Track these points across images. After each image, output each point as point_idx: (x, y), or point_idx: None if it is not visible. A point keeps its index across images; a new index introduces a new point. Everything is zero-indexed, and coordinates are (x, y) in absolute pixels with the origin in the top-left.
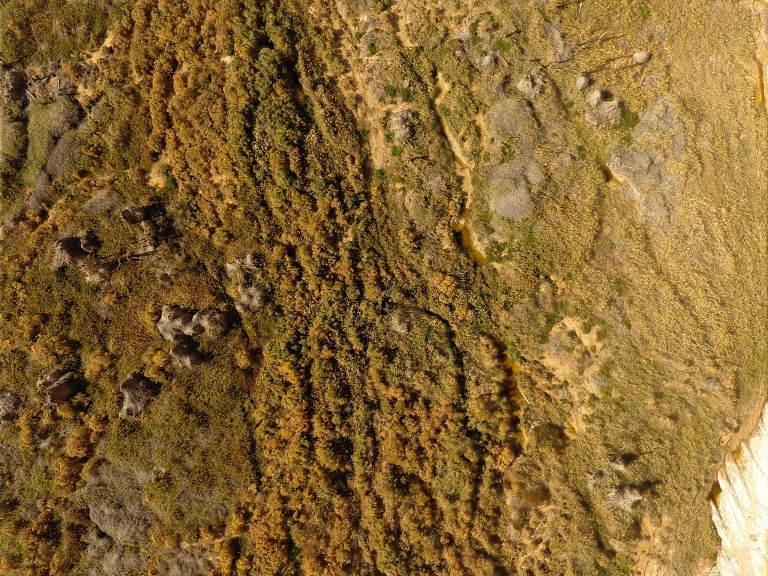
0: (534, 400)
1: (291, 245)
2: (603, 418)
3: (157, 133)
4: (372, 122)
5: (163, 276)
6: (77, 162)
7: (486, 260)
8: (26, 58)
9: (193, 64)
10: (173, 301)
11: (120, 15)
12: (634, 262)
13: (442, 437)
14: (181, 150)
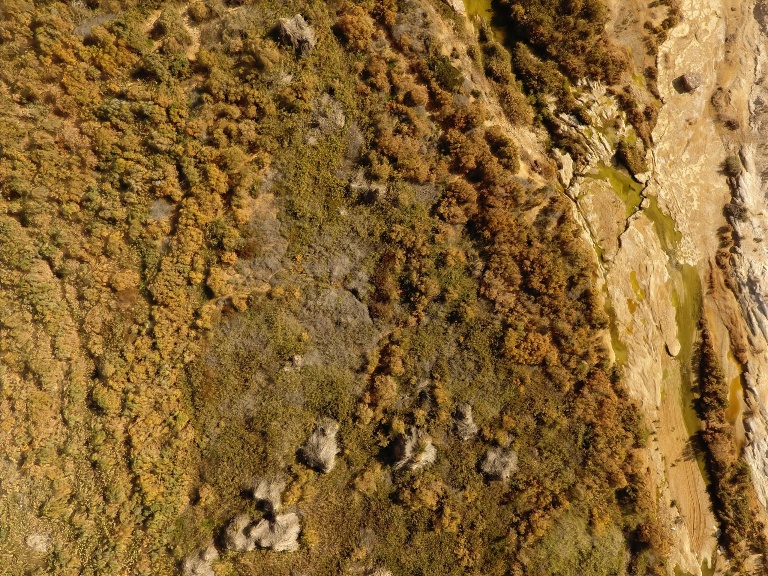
0: None
1: None
2: None
3: None
4: None
5: None
6: None
7: None
8: None
9: None
10: (287, 556)
11: None
12: None
13: None
14: None
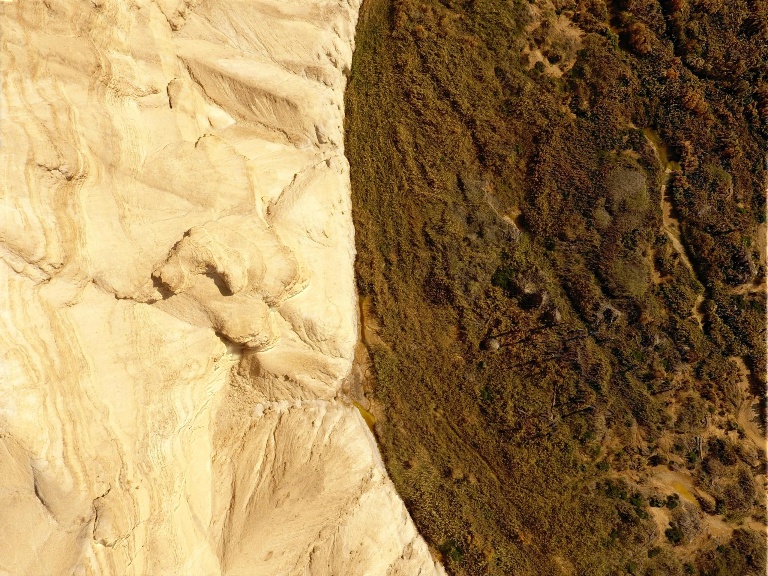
0: None
1: None
2: None
3: None
4: None
5: None
6: None
7: None
8: None
9: None
10: None
11: None
12: None
13: None
14: None
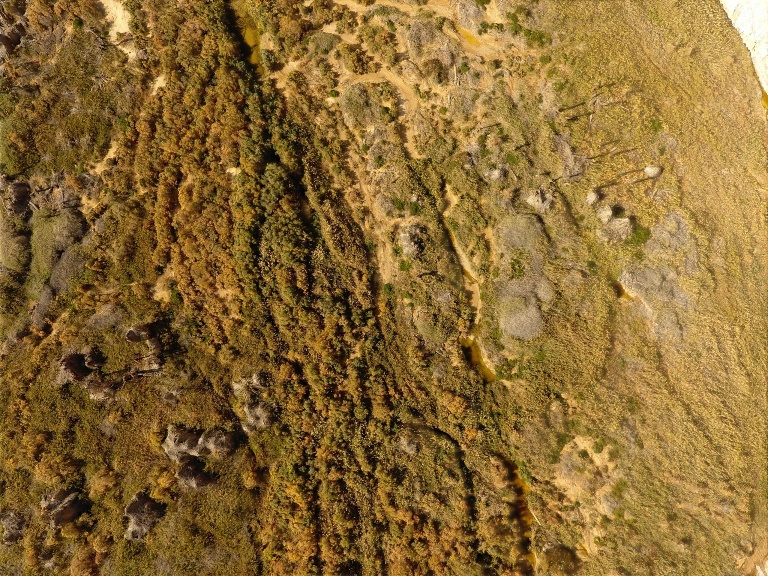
0: (545, 522)
1: (298, 362)
2: (616, 541)
3: (162, 248)
4: (380, 235)
5: (168, 396)
6: (81, 277)
7: (496, 377)
8: (29, 169)
9: (198, 177)
10: (179, 420)
11: (124, 126)
12: (646, 381)
13: (452, 561)
14: (186, 264)
